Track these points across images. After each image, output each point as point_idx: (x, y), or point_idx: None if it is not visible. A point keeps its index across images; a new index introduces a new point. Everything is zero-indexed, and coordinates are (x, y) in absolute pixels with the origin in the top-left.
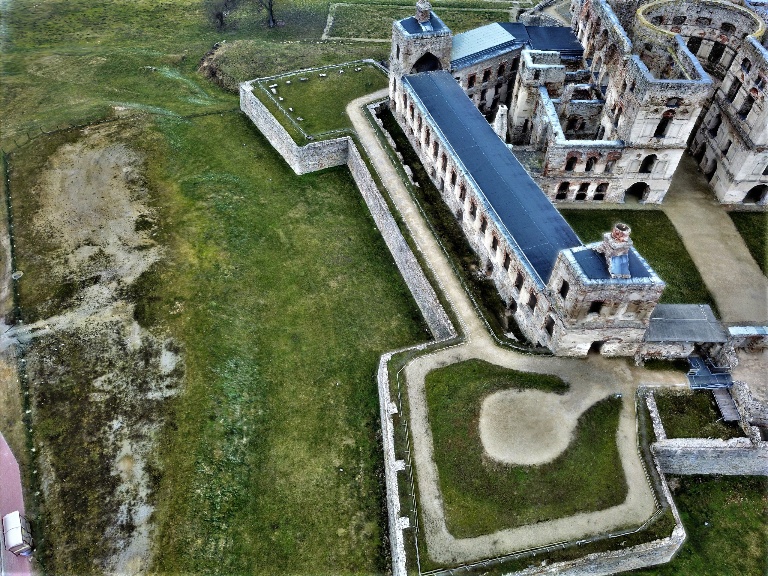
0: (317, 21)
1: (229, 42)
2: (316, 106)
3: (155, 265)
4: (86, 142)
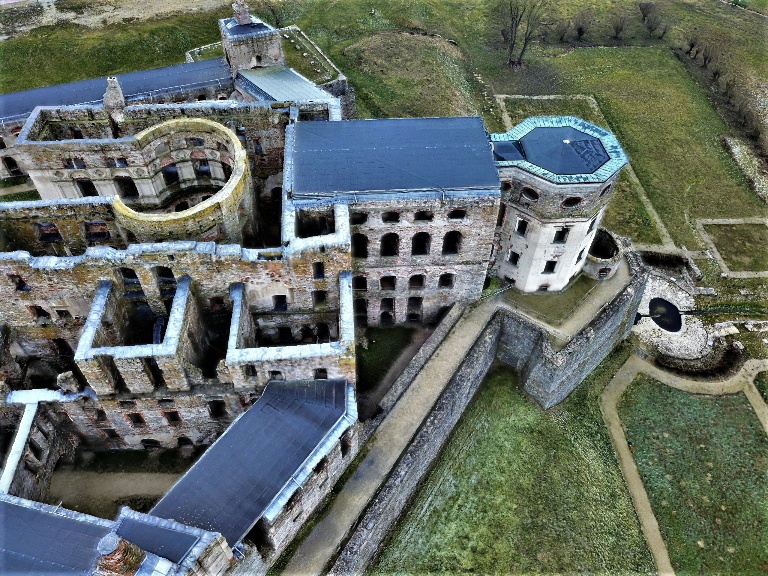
0: (537, 89)
1: (463, 47)
2: None
3: (85, 26)
4: None
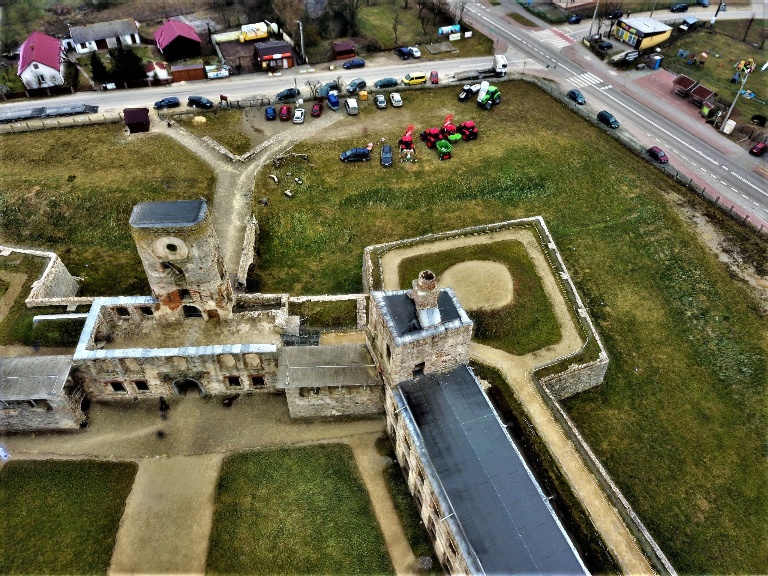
0: None
1: None
2: None
3: None
4: None
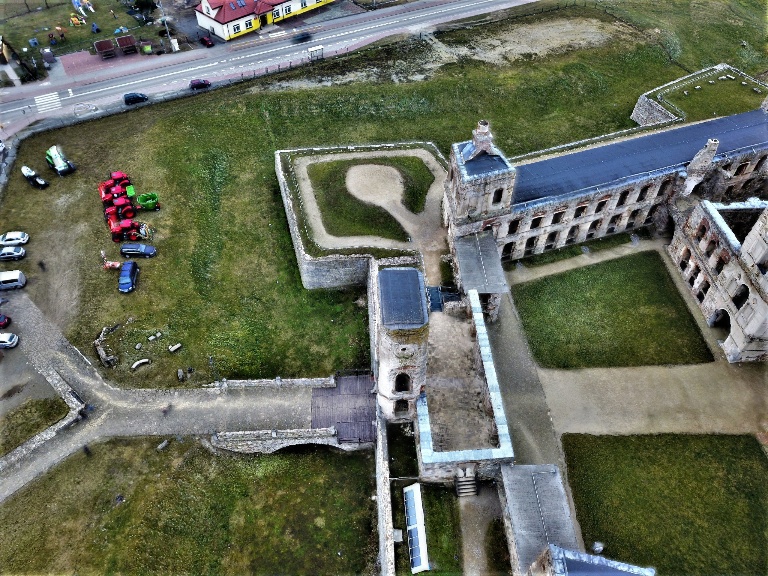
0: None
1: None
2: (715, 100)
3: (491, 64)
4: (604, 25)
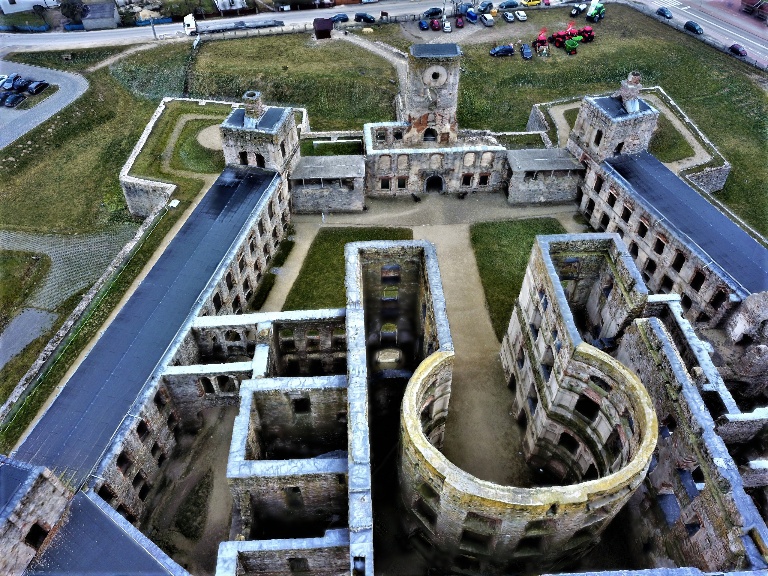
0: None
1: None
2: None
3: None
4: None
